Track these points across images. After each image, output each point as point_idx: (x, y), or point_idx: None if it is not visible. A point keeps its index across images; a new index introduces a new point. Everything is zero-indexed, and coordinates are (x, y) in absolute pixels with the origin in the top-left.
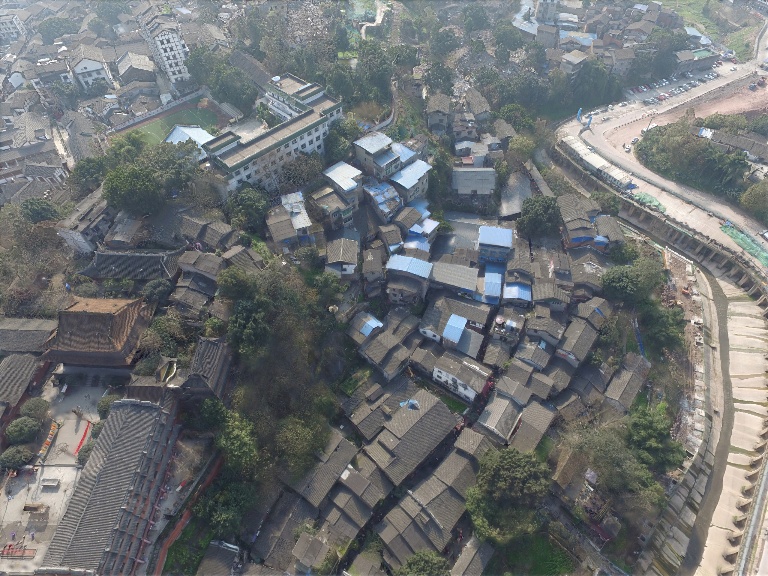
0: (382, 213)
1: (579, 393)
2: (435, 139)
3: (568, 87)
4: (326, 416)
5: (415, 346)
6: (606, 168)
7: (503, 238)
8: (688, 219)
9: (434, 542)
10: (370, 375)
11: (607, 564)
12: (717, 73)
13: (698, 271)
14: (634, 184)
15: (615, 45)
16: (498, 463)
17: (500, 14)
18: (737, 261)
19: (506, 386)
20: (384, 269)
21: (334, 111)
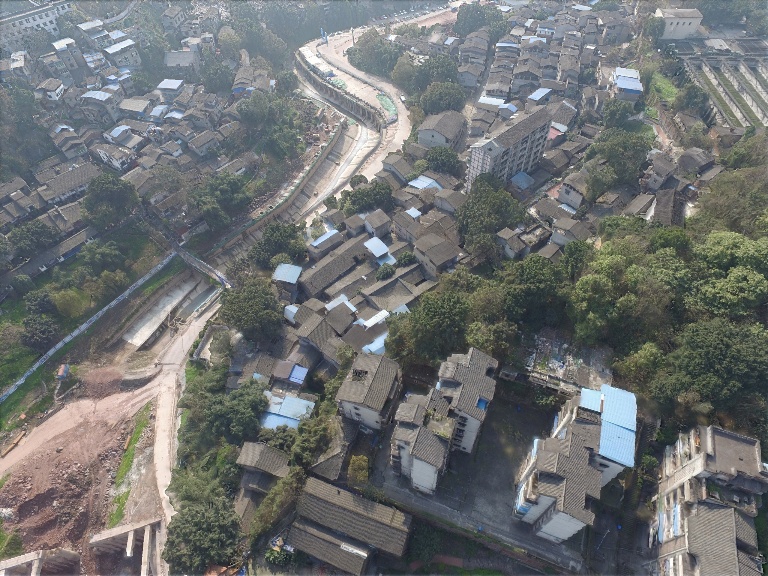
0: (90, 68)
1: (197, 168)
2: (164, 35)
3: (320, 15)
4: (17, 172)
5: (95, 143)
6: (318, 64)
7: (174, 84)
8: (358, 92)
9: (59, 225)
10: (56, 155)
11: (184, 253)
12: (448, 5)
13: (357, 125)
14: (334, 74)
15: None
16: (96, 179)
17: None
18: (376, 114)
19: (141, 160)
20: (82, 99)
21: (65, 5)
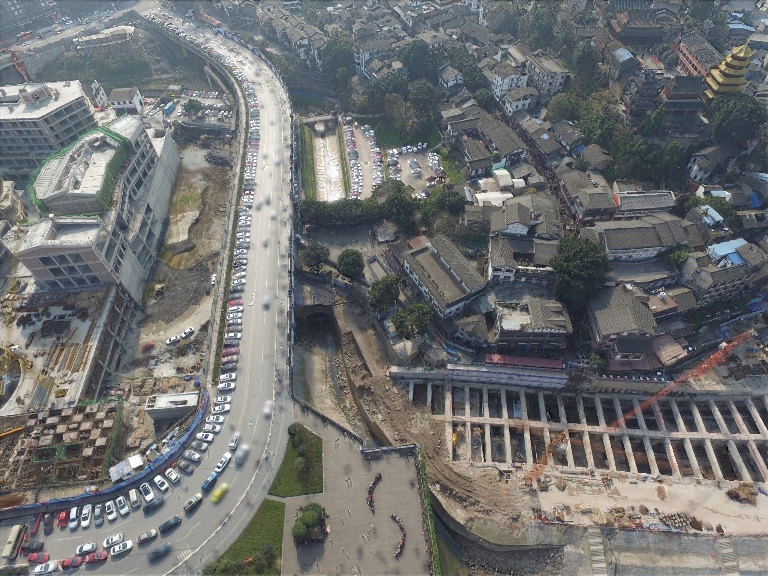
0: None
1: None
2: None
3: None
4: None
5: None
6: None
7: None
8: None
9: None
10: None
11: None
12: None
13: None
14: None
15: None
16: None
17: None
18: None
19: None
20: None
21: None
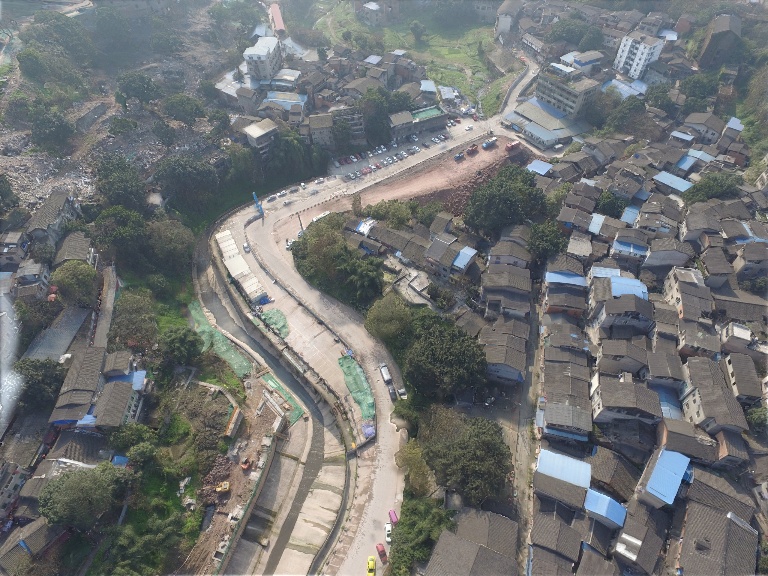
0: None
1: None
2: None
3: (254, 164)
4: None
5: None
6: (242, 276)
7: None
8: (308, 347)
9: None
10: None
11: None
12: (447, 134)
13: (305, 419)
14: (269, 297)
15: (327, 108)
16: None
17: (206, 74)
18: (337, 410)
19: None
20: None
21: None
